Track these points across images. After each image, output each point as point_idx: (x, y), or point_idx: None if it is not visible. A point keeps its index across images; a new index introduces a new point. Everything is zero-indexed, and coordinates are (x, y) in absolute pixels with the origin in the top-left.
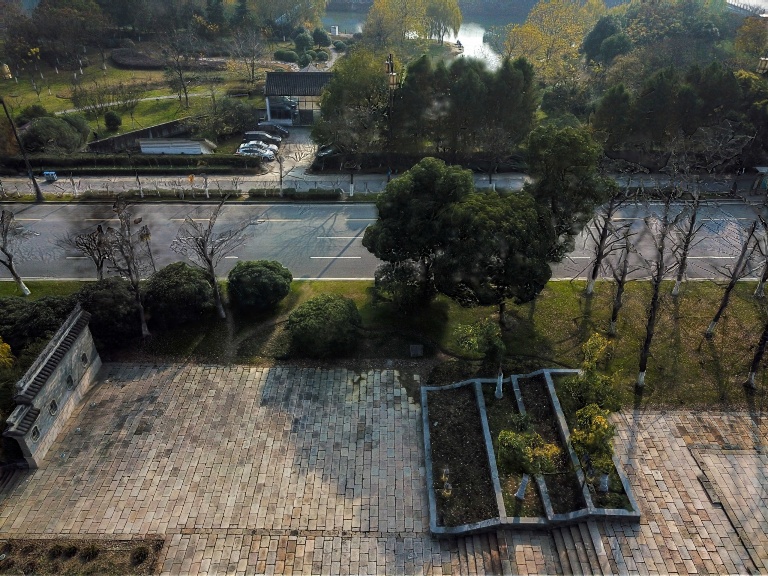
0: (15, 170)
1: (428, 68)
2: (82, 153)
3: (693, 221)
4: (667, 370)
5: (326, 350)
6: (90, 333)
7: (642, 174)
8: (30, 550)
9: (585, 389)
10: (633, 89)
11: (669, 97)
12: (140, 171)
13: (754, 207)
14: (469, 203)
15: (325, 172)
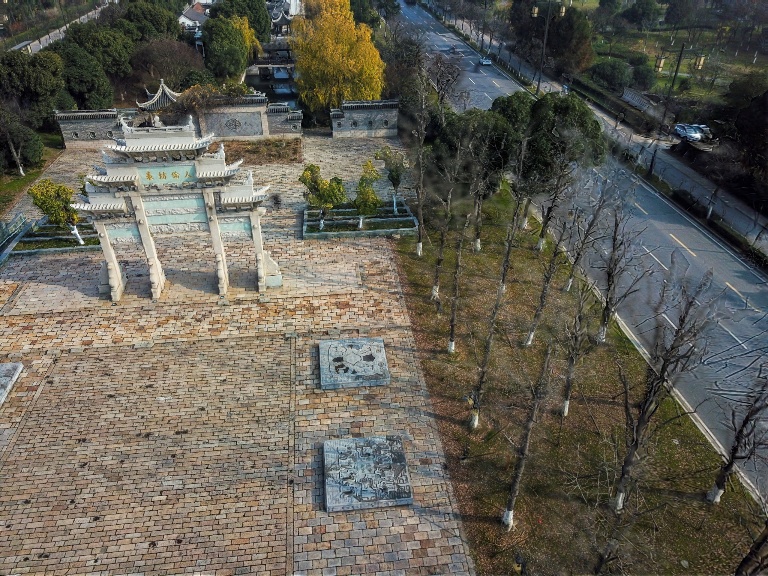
0: (563, 81)
1: None
2: (597, 85)
3: (592, 224)
4: None
5: (415, 167)
6: (397, 116)
7: None
8: (296, 145)
9: None
10: None
11: None
12: (597, 104)
13: None
14: (474, 109)
15: (671, 153)
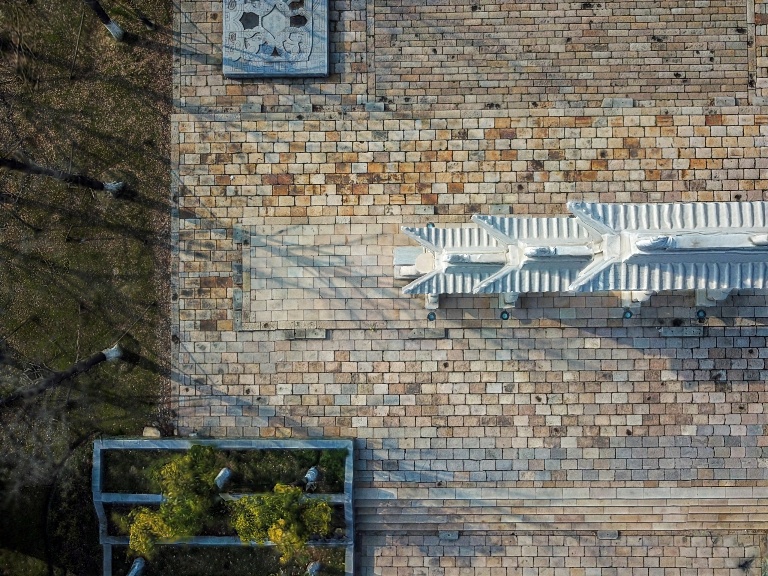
0: None
1: None
2: None
3: None
4: (84, 299)
5: None
6: None
7: None
8: None
9: (194, 516)
10: None
11: None
12: None
13: None
14: None
15: None
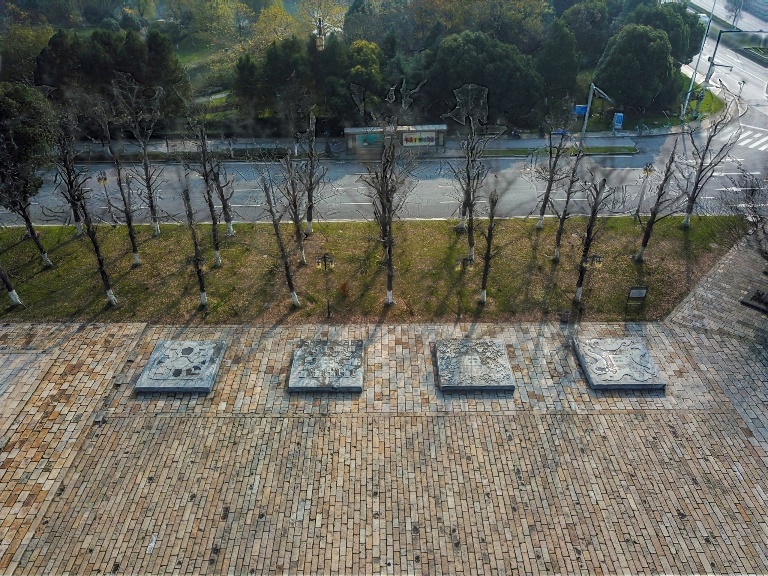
0: None
1: (63, 41)
2: None
3: (146, 166)
4: (57, 293)
5: None
6: None
7: (271, 138)
8: None
9: None
10: (259, 59)
11: (279, 65)
12: None
13: (339, 164)
14: None
15: None
